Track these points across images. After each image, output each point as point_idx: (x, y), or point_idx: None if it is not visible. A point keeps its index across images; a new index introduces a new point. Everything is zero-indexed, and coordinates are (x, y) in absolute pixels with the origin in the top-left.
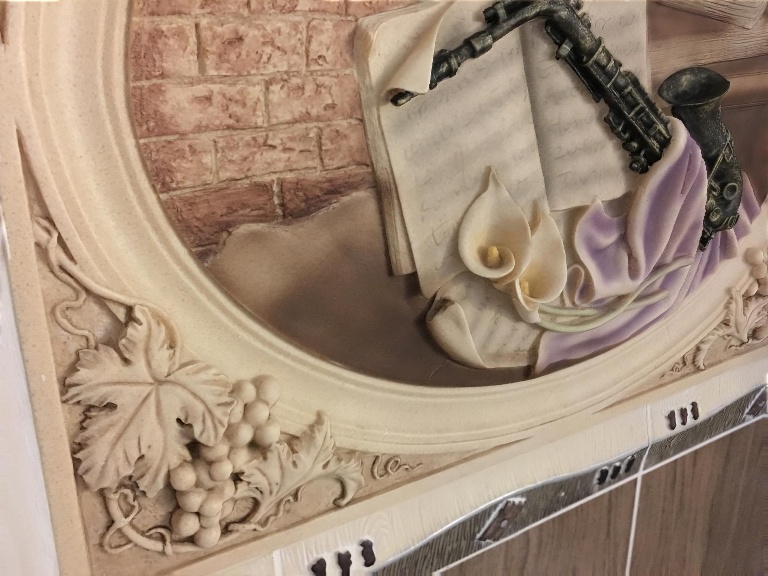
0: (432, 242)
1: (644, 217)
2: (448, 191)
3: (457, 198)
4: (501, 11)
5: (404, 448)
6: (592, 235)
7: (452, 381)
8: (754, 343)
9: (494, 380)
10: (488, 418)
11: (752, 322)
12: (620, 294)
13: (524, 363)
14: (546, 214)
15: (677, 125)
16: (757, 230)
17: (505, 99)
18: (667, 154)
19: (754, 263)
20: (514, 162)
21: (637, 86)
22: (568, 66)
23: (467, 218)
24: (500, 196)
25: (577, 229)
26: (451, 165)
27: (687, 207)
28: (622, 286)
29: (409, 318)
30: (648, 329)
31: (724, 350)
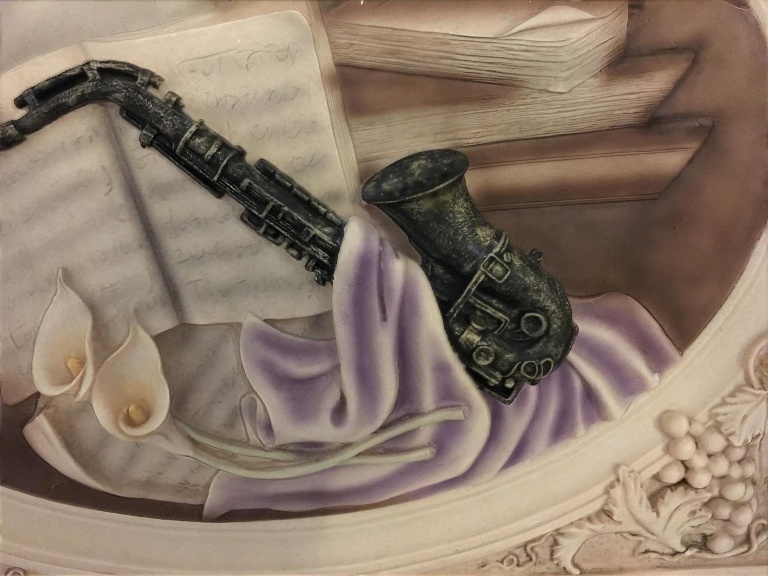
0: (11, 344)
1: (350, 346)
2: (21, 291)
3: (33, 299)
4: (29, 98)
5: (18, 561)
6: (271, 360)
7: (84, 501)
8: (706, 557)
9: (149, 512)
10: (157, 555)
11: (682, 524)
12: (330, 441)
13: (195, 501)
14: (138, 329)
15: (347, 230)
16: (688, 385)
17: (72, 193)
18: (337, 267)
19: (670, 434)
20: (93, 265)
21: (273, 178)
22: (161, 155)
23: (42, 323)
24: (72, 302)
25: (242, 350)
26: (18, 263)
27: (413, 340)
28: (322, 432)
29: (11, 421)
30: (440, 496)
31: (631, 554)
